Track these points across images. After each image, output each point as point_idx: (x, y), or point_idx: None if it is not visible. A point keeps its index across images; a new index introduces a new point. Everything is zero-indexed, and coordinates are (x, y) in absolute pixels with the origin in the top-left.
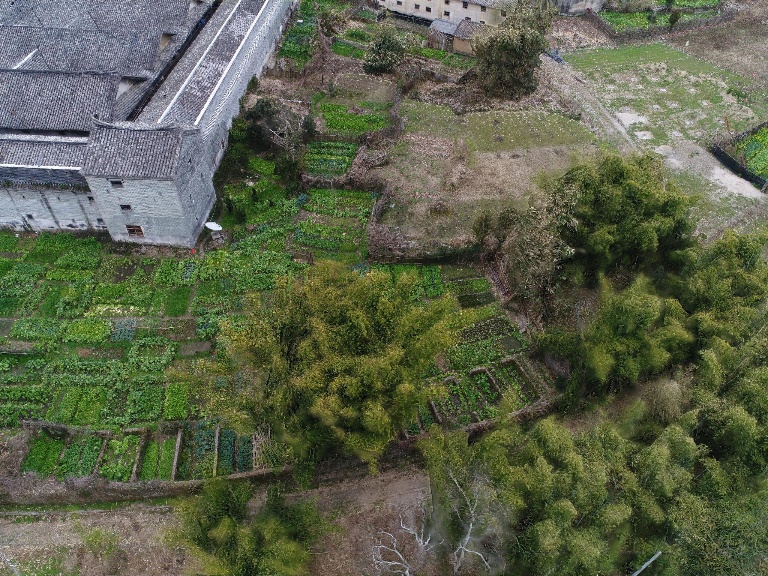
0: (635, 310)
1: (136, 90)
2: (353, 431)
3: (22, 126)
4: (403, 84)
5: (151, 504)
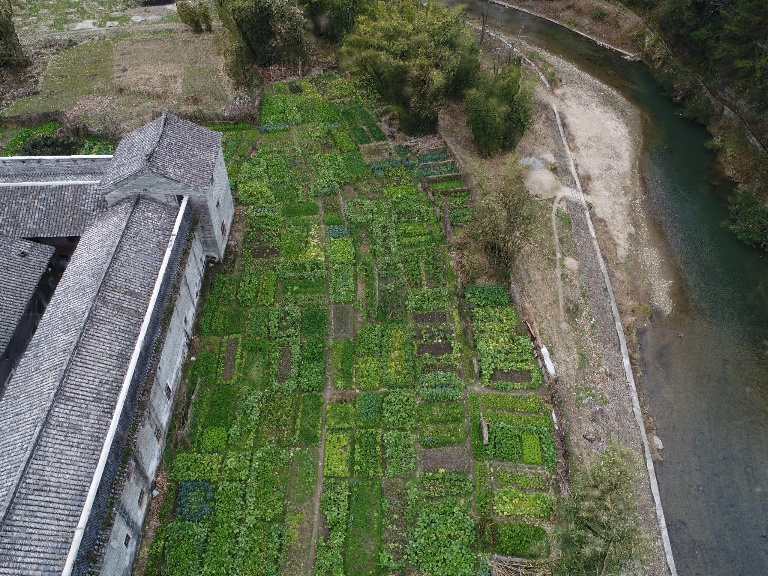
0: None
1: None
2: None
3: (6, 338)
4: None
5: None
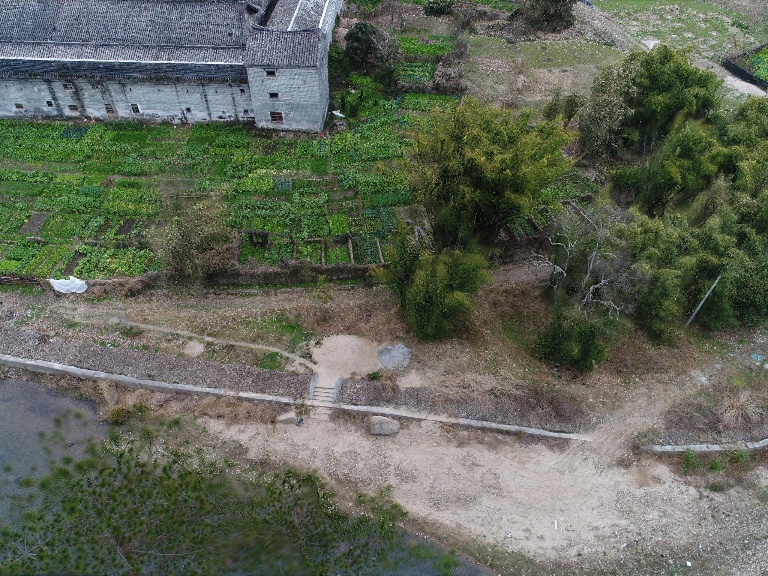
0: (689, 134)
1: (252, 19)
2: (510, 192)
3: (170, 43)
4: (462, 20)
5: (339, 283)
